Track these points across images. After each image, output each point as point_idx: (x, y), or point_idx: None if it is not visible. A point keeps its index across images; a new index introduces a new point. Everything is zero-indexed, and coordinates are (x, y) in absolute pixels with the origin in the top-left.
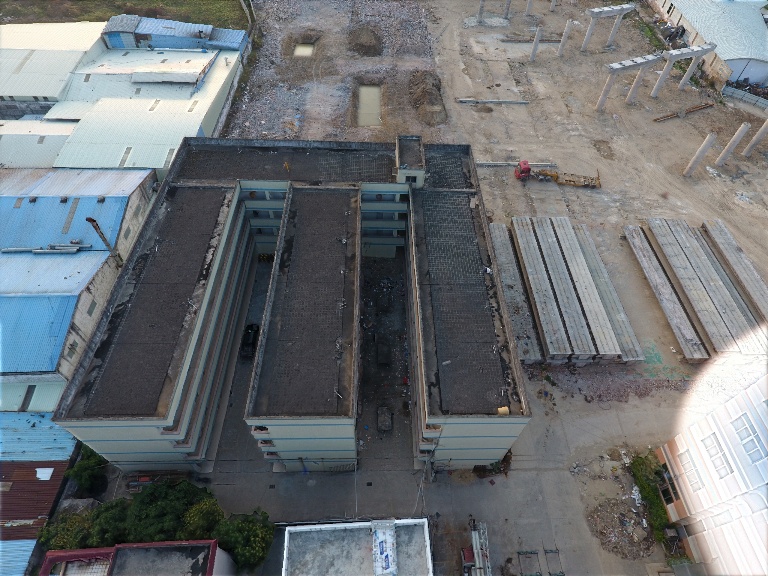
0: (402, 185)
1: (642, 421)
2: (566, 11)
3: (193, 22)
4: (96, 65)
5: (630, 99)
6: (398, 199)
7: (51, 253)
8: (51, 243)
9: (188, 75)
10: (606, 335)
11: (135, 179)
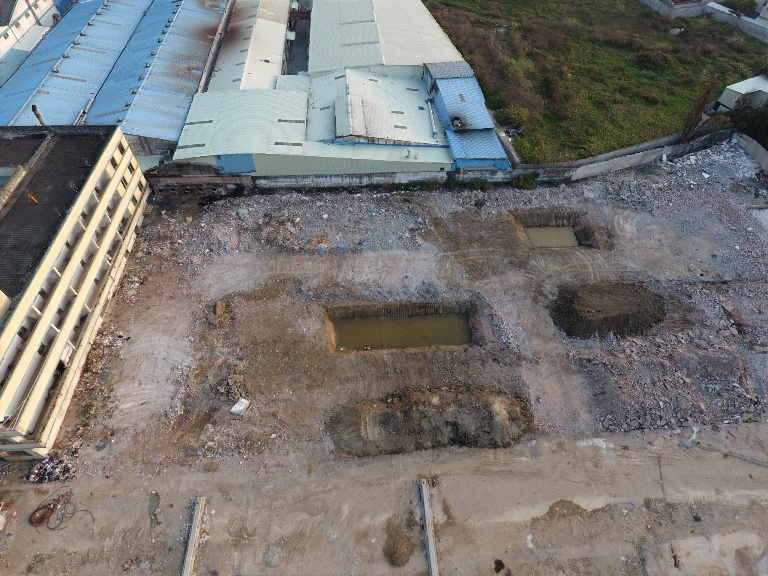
0: None
1: None
2: None
3: (557, 124)
4: (372, 77)
5: None
6: None
7: None
8: None
9: (347, 128)
10: None
11: (156, 133)
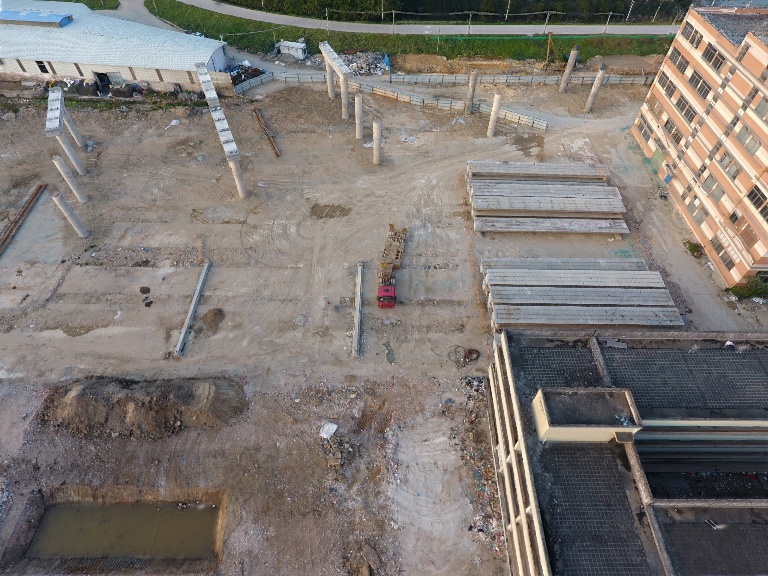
0: None
1: (692, 280)
2: None
3: None
4: None
5: None
6: None
7: None
8: None
9: None
10: (643, 277)
11: None
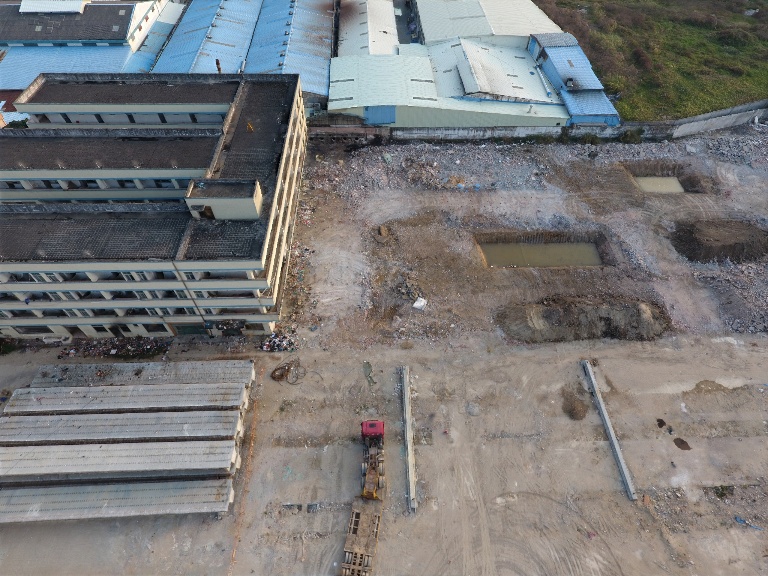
0: None
1: None
2: None
3: (651, 91)
4: (483, 46)
5: None
6: None
7: None
8: None
9: (474, 86)
10: (3, 462)
11: (309, 88)
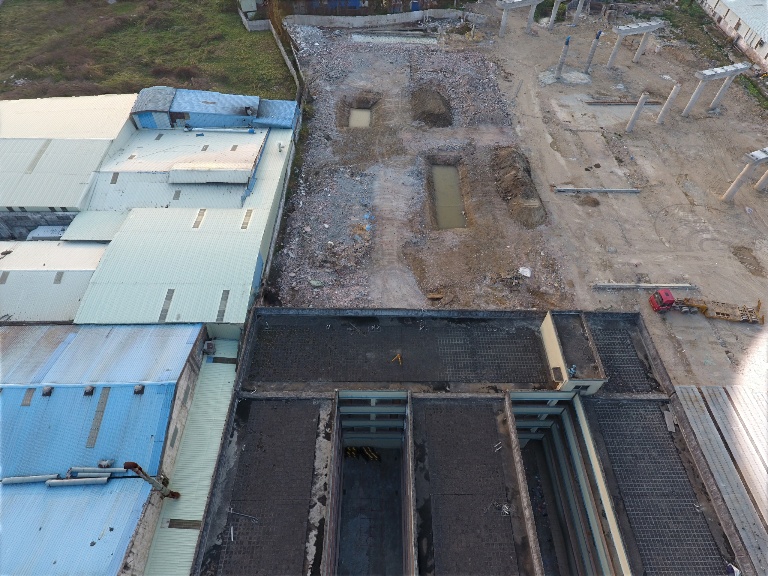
0: (566, 393)
1: None
2: (652, 62)
3: (231, 84)
4: (125, 157)
5: (762, 186)
6: (554, 404)
7: (72, 485)
8: (72, 467)
9: (238, 173)
10: None
11: (181, 346)
